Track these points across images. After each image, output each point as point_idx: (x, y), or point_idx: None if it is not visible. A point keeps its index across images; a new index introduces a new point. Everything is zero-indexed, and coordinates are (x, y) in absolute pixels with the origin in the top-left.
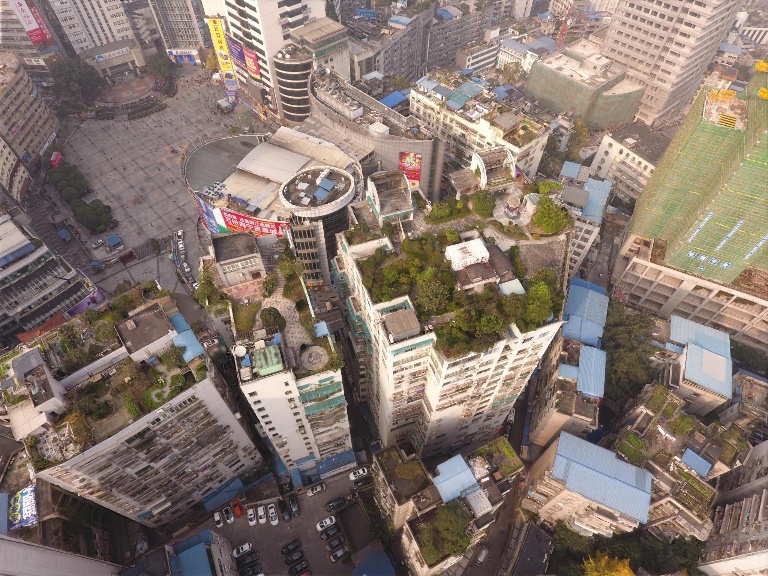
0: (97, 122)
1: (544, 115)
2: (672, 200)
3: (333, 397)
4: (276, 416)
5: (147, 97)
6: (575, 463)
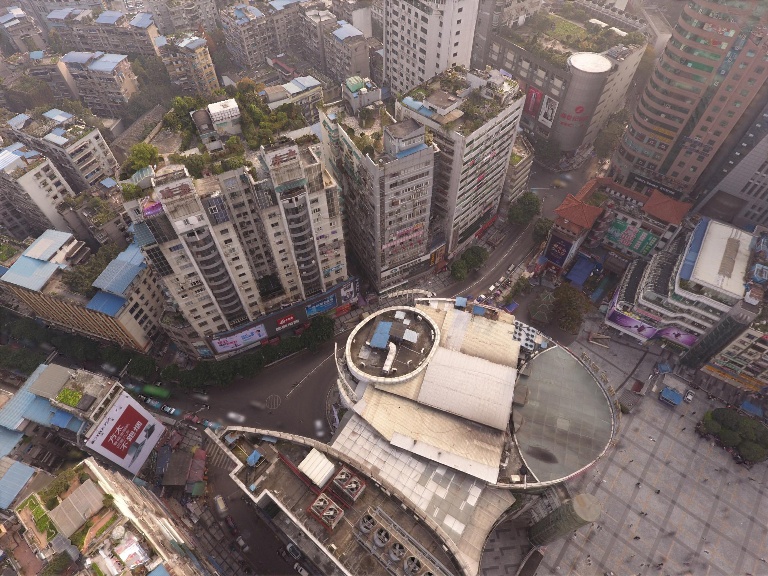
0: None
1: None
2: None
3: None
4: None
5: None
6: None
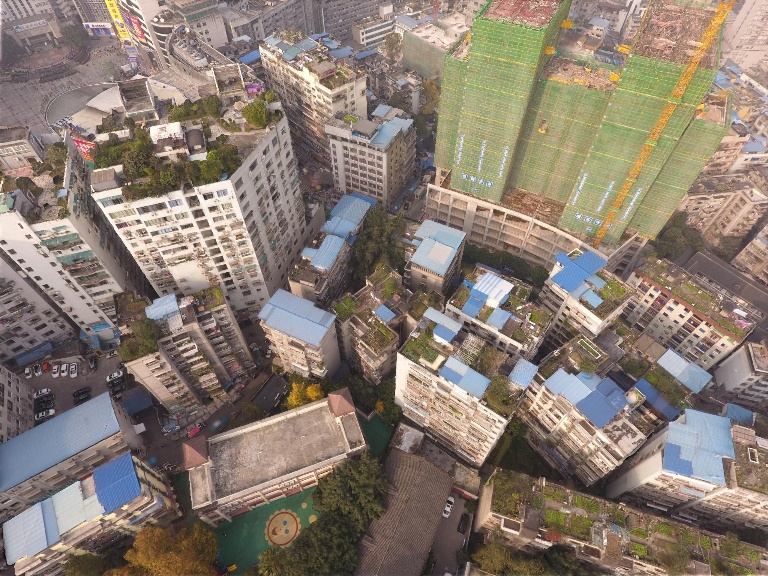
0: (12, 84)
1: (400, 75)
2: (451, 131)
3: (82, 251)
4: (33, 263)
5: (59, 63)
6: (278, 308)
